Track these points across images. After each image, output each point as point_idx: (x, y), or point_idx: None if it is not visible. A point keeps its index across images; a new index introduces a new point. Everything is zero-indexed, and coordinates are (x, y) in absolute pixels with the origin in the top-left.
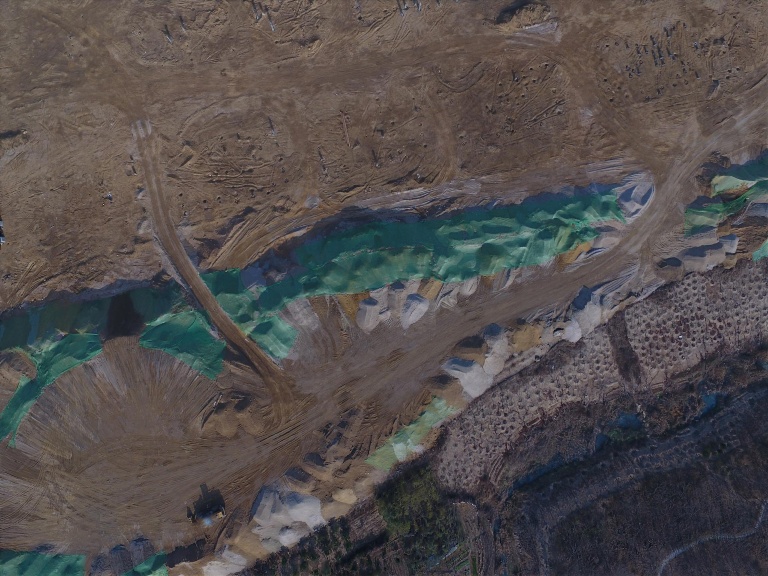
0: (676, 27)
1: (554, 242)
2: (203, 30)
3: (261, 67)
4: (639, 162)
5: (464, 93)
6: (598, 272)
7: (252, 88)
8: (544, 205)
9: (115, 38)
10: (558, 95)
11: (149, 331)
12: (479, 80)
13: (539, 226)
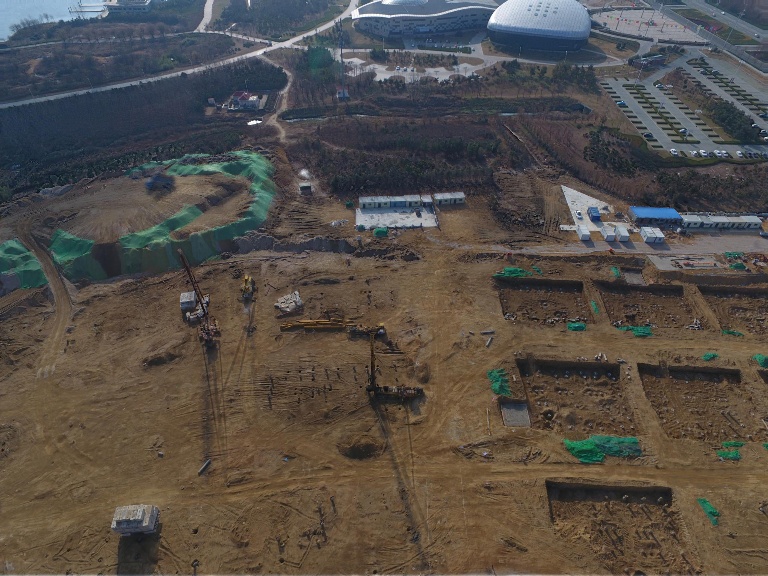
0: None
1: None
2: None
3: None
4: None
5: None
6: None
7: None
8: None
9: (31, 445)
10: None
11: (89, 249)
12: None
13: None
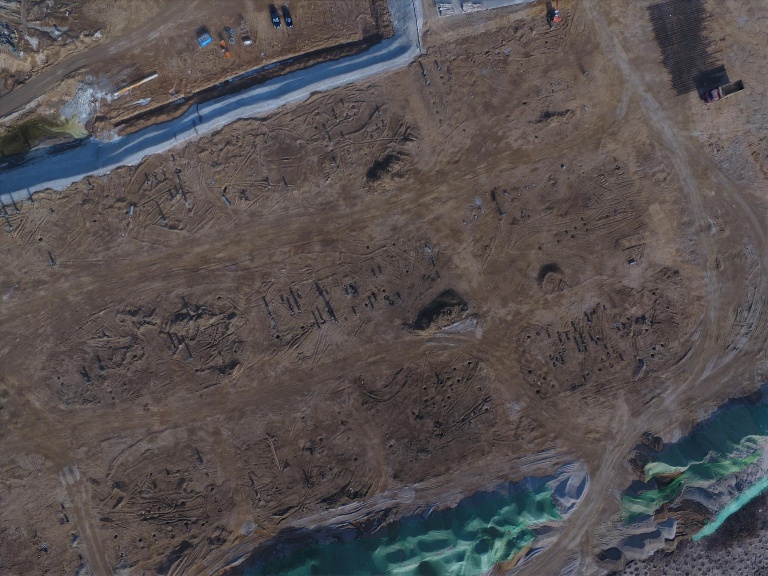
0: (596, 310)
1: (491, 553)
2: (121, 368)
3: (183, 398)
4: (571, 451)
5: (389, 401)
6: (539, 573)
7: (177, 420)
8: (479, 510)
9: (34, 385)
10: (484, 392)
11: None
12: (403, 387)
13: (475, 536)
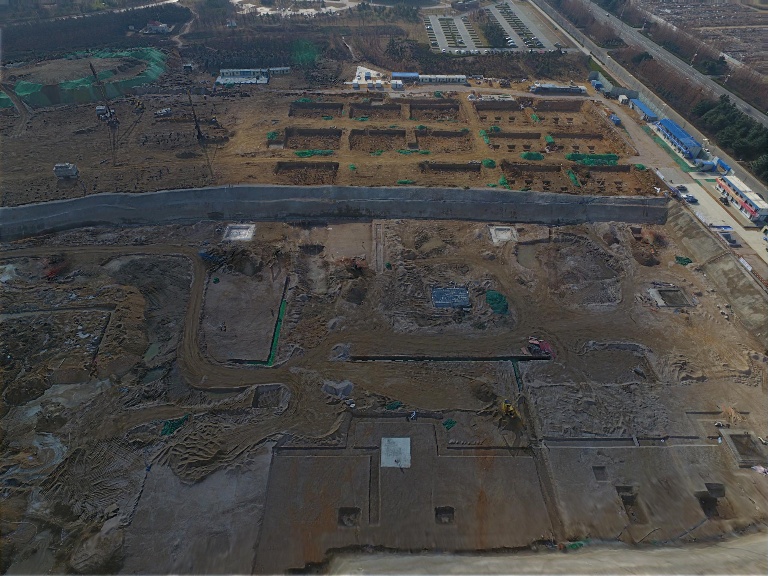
0: None
1: None
2: None
3: None
4: None
5: None
6: None
7: None
8: None
9: None
10: None
11: None
12: None
13: None
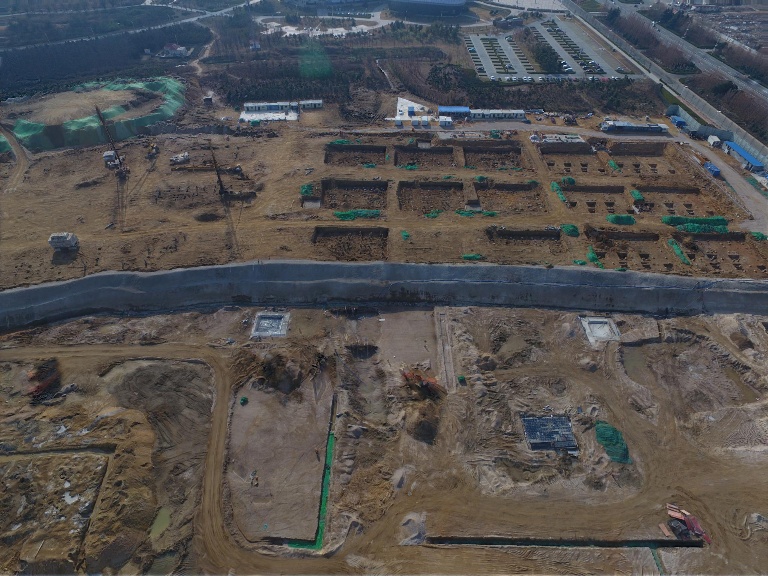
0: None
1: None
2: None
3: None
4: None
5: None
6: None
7: None
8: None
9: (0, 220)
10: None
11: (41, 130)
12: None
13: None
